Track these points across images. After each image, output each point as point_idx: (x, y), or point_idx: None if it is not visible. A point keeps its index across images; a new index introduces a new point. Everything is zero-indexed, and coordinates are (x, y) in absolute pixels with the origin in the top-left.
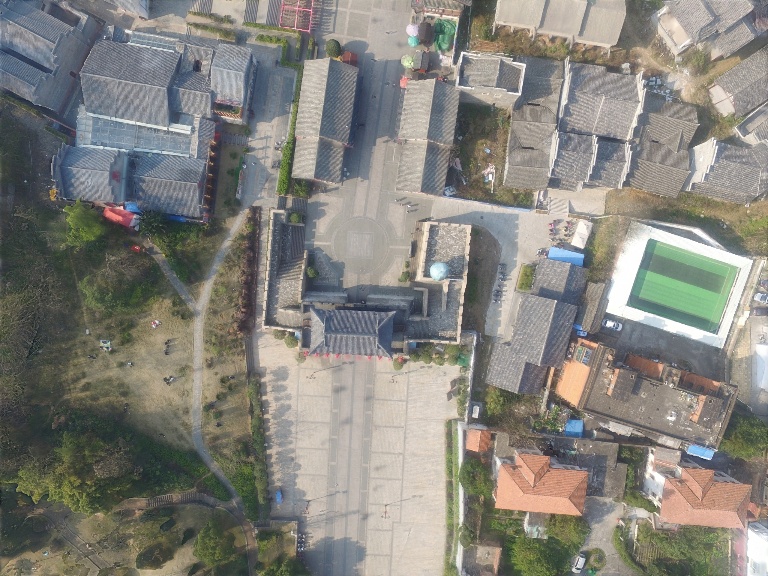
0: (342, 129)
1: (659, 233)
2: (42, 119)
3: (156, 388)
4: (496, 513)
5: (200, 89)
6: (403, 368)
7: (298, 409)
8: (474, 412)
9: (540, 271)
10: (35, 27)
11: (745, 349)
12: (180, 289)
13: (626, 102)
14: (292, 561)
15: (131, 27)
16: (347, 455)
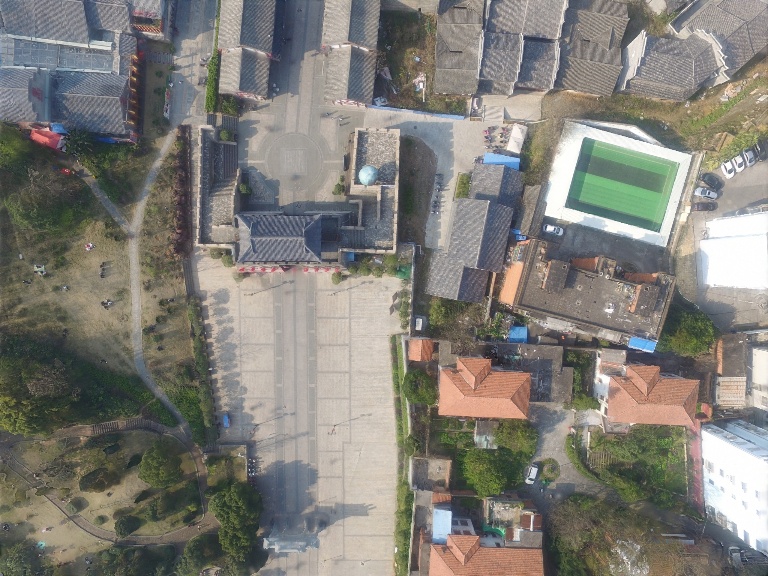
0: (264, 38)
1: (594, 132)
2: None
3: (94, 312)
4: (445, 427)
5: (117, 2)
6: (344, 284)
7: (241, 332)
8: (417, 325)
9: (476, 177)
10: None
11: (689, 246)
12: (112, 211)
13: None
14: (241, 483)
15: None
16: (293, 376)
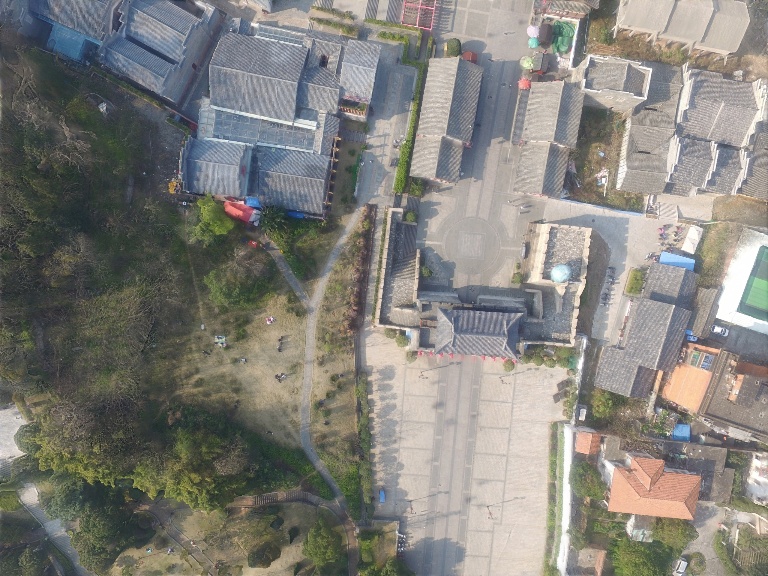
0: (466, 129)
1: None
2: (163, 111)
3: (267, 385)
4: (599, 516)
5: (329, 85)
6: None
7: (403, 409)
8: (581, 415)
9: (652, 275)
10: (163, 17)
11: None
12: (295, 286)
13: (745, 109)
14: (396, 561)
15: (253, 20)
16: (451, 456)
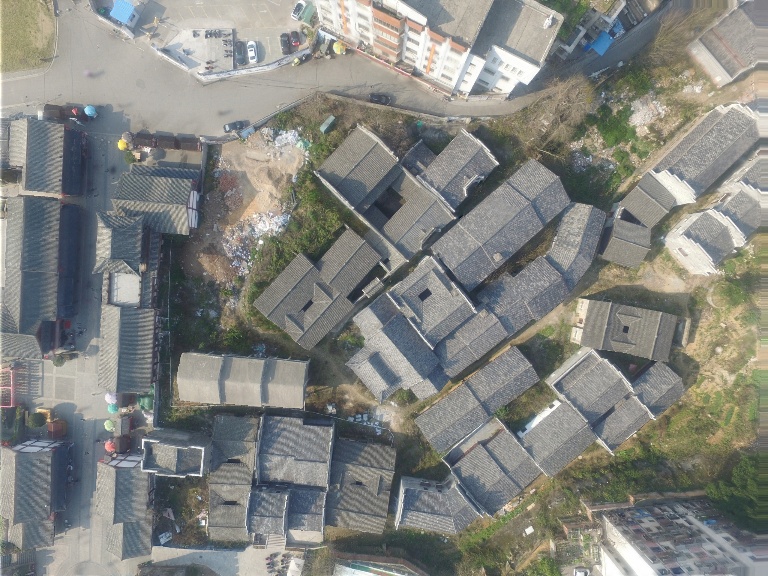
0: (41, 509)
1: (362, 574)
2: None
3: None
4: None
5: None
6: None
7: None
8: None
9: None
10: None
11: None
12: None
13: (315, 463)
14: None
15: None
16: None
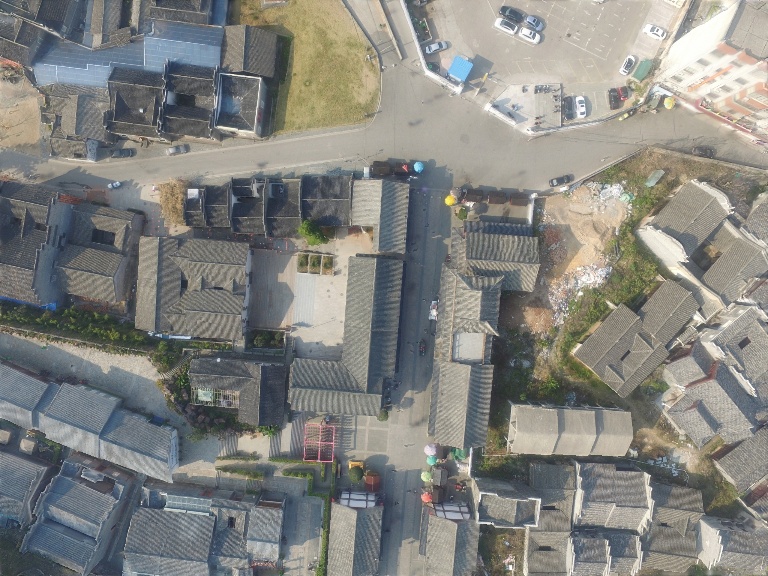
0: (372, 563)
1: None
2: (89, 575)
3: None
4: None
5: (237, 554)
6: None
7: None
8: None
9: None
10: (76, 508)
11: None
12: None
13: (636, 508)
14: None
15: None
16: None
